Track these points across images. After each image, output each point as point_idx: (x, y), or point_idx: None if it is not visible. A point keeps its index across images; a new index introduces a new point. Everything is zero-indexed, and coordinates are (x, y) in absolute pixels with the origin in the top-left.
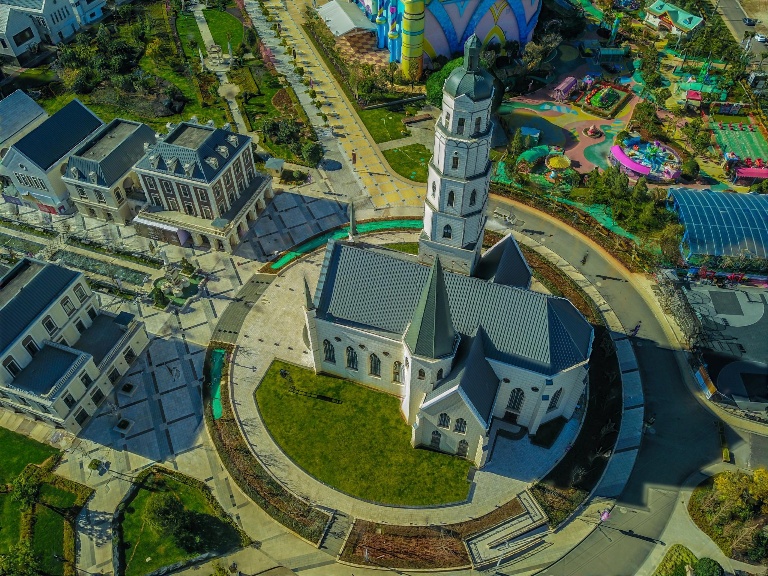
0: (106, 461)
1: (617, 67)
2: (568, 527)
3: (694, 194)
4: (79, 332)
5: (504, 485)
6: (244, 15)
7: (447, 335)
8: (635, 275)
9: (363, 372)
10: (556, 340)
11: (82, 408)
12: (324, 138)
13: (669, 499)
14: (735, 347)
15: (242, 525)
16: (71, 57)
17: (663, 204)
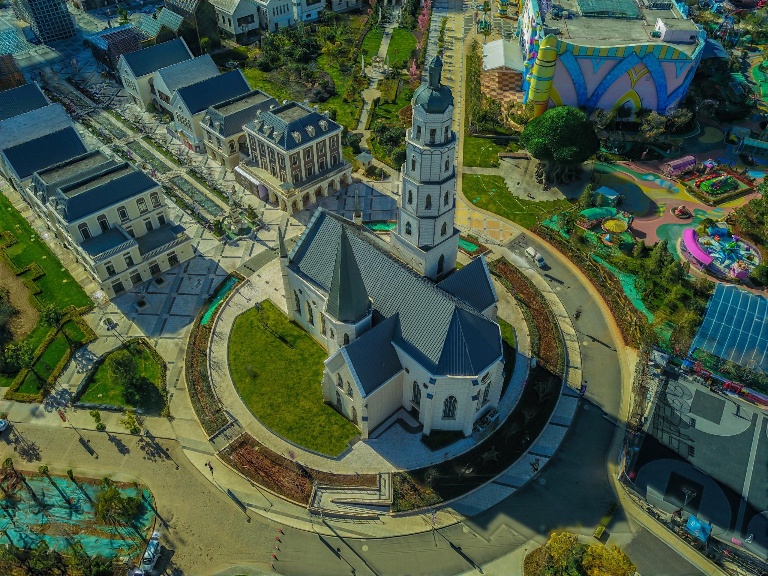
0: (116, 323)
1: (757, 160)
2: (407, 518)
3: (740, 295)
4: (147, 230)
5: (375, 461)
6: (424, 38)
7: (351, 303)
8: (627, 348)
9: (317, 329)
10: (451, 346)
11: (120, 281)
12: None
13: (515, 541)
14: (685, 448)
15: (171, 402)
16: (270, 42)
17: (707, 297)
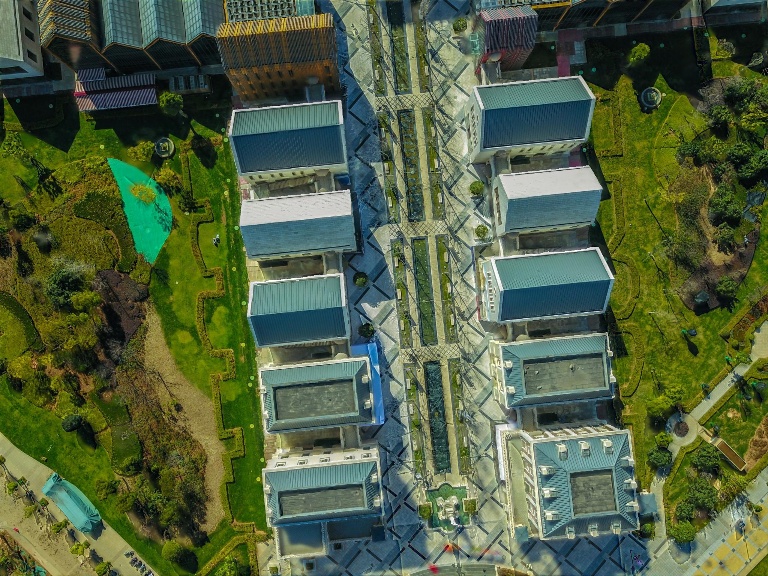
0: (280, 574)
1: None
2: None
3: None
4: None
5: None
6: None
7: None
8: None
9: None
10: None
11: None
12: (726, 516)
13: None
14: None
15: None
16: (740, 93)
17: None
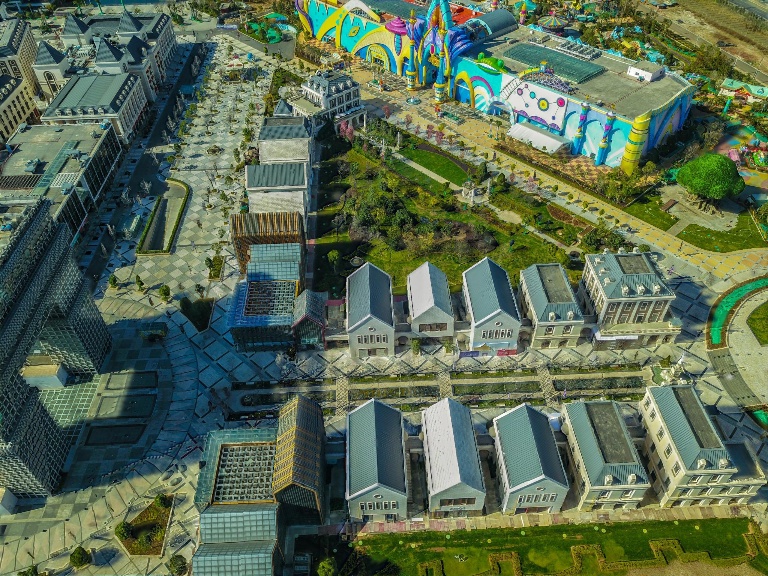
0: None
1: None
2: None
3: None
4: None
5: None
6: (438, 149)
7: None
8: None
9: None
10: None
11: None
12: (626, 237)
13: None
14: None
15: None
16: (362, 221)
17: None
